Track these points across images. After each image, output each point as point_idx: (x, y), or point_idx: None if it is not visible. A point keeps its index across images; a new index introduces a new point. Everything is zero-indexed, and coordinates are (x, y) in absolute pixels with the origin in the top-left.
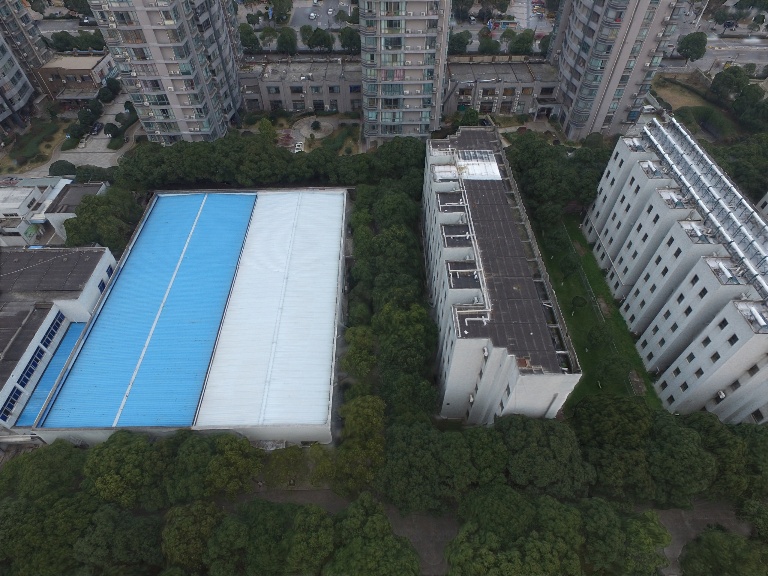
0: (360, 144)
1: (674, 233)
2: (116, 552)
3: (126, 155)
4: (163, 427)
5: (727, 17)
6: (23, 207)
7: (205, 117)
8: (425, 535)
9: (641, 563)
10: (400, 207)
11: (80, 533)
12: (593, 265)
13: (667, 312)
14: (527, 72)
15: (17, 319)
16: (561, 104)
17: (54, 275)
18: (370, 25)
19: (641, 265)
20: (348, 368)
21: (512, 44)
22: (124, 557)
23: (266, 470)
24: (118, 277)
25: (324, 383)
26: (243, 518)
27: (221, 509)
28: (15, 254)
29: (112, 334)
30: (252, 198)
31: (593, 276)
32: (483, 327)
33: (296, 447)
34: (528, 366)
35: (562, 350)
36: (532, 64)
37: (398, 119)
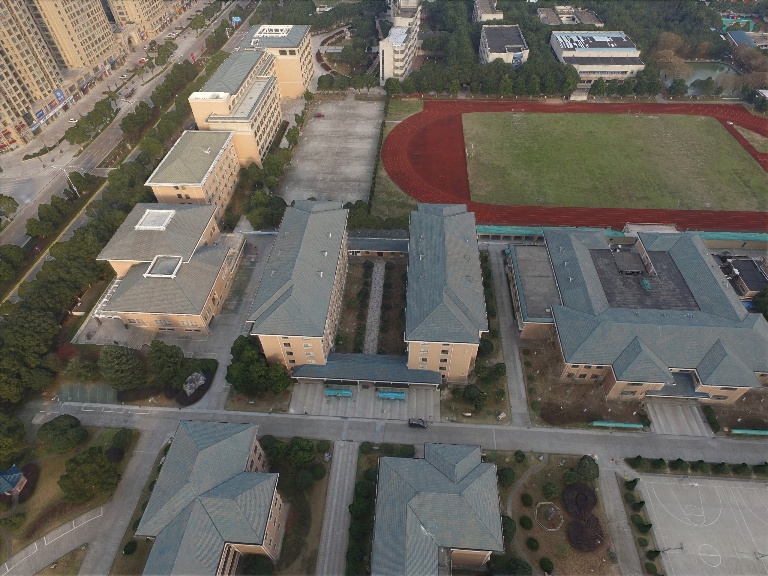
0: None
1: None
2: None
3: None
4: None
5: None
6: None
7: None
8: None
9: (591, 6)
10: None
11: None
12: None
13: None
14: None
15: None
16: None
17: None
18: None
19: None
20: None
21: None
22: None
23: None
24: None
25: (534, 0)
26: None
27: None
28: None
29: None
30: None
31: None
32: None
33: None
34: None
35: None
36: None
37: None
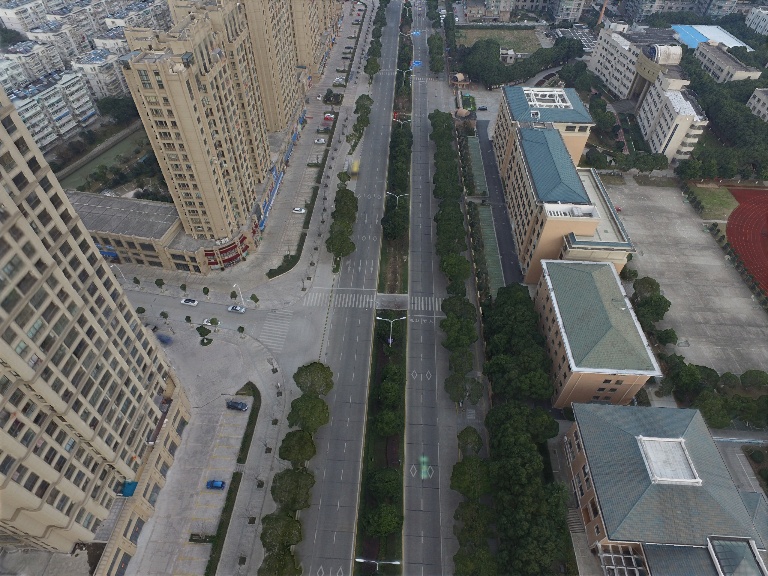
0: None
1: None
2: None
3: None
4: None
5: None
6: None
7: None
8: None
9: None
10: None
11: None
12: None
13: None
14: None
15: None
16: None
17: None
18: None
19: None
20: (753, 45)
21: None
22: None
23: None
24: None
25: (747, 48)
26: None
27: None
28: None
29: None
30: None
31: None
32: None
33: None
34: None
35: None
36: None
37: (719, 13)
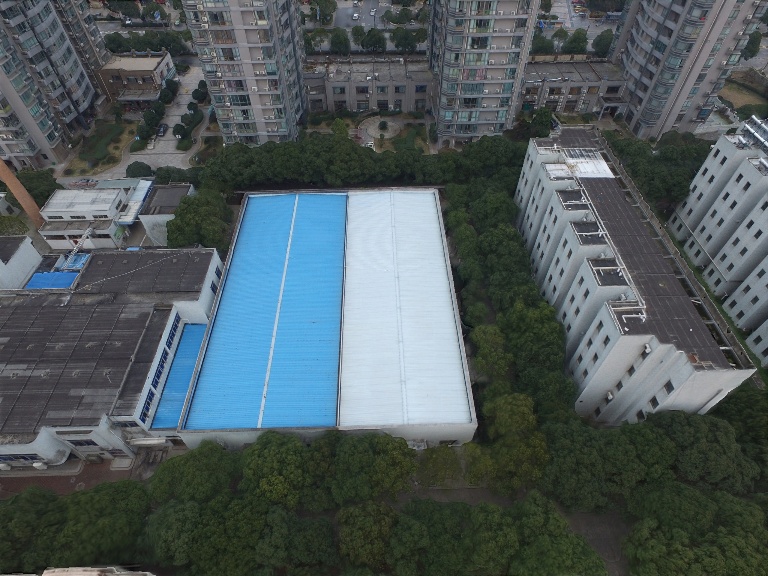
0: (430, 144)
1: None
2: (297, 553)
3: (198, 156)
4: (309, 428)
5: None
6: (112, 209)
7: (284, 117)
8: (576, 533)
9: None
10: (503, 206)
11: (259, 535)
12: None
13: None
14: (591, 71)
15: (140, 321)
16: (628, 103)
17: (167, 276)
18: (459, 24)
19: (753, 261)
20: (484, 367)
21: (566, 43)
22: (305, 558)
23: (423, 469)
24: (227, 278)
25: (459, 382)
26: (415, 518)
27: (391, 509)
28: (122, 256)
29: (234, 335)
30: (343, 198)
31: None
32: (642, 324)
33: (447, 446)
34: (698, 362)
35: (725, 346)
36: (594, 63)
37: (474, 118)
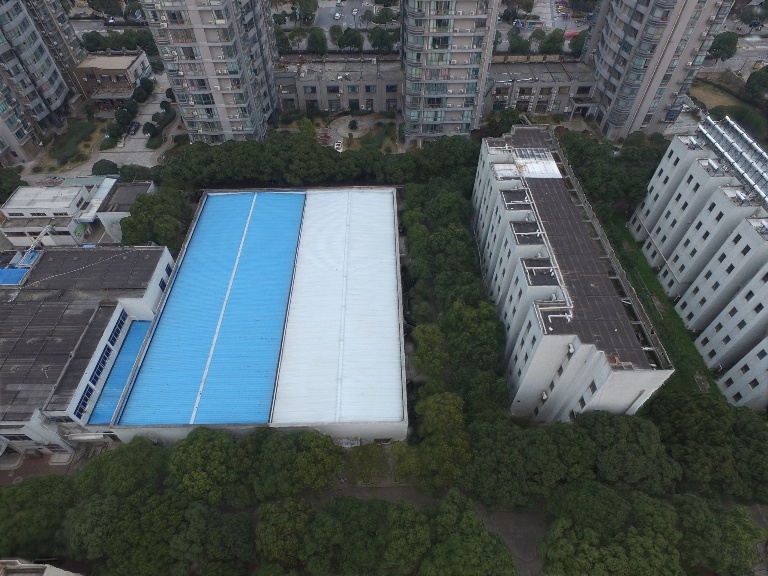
0: (398, 143)
1: (742, 230)
2: (211, 549)
3: (166, 154)
4: (241, 424)
5: (753, 17)
6: (73, 206)
7: (249, 116)
8: (504, 532)
9: (737, 558)
10: (455, 205)
11: (175, 530)
12: (644, 263)
13: (733, 309)
14: (563, 71)
15: (84, 317)
16: (598, 103)
17: (115, 273)
18: (419, 24)
19: (701, 263)
20: (420, 365)
21: (543, 44)
22: (220, 554)
23: (349, 467)
24: (177, 275)
25: (395, 380)
26: (333, 515)
27: (310, 506)
28: (74, 253)
29: (178, 332)
30: (301, 197)
31: (645, 274)
32: (567, 324)
33: (376, 444)
34: (617, 362)
35: (648, 346)
36: (566, 63)
37: (440, 118)
